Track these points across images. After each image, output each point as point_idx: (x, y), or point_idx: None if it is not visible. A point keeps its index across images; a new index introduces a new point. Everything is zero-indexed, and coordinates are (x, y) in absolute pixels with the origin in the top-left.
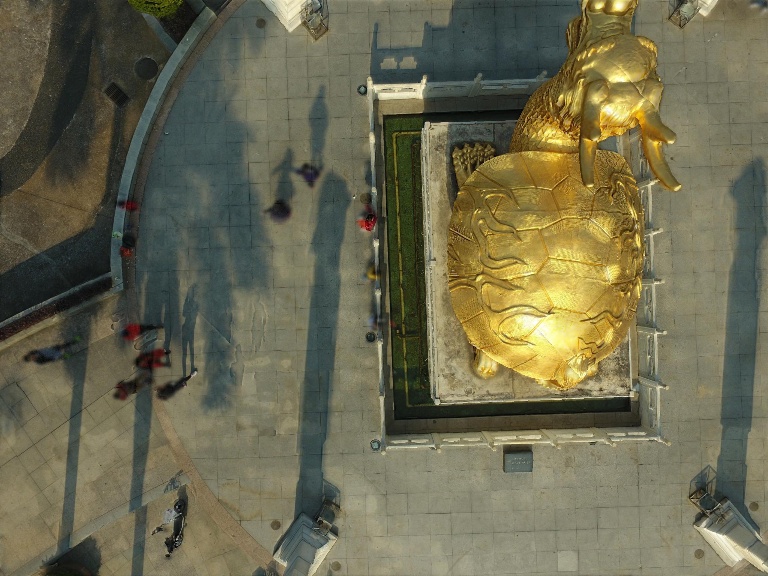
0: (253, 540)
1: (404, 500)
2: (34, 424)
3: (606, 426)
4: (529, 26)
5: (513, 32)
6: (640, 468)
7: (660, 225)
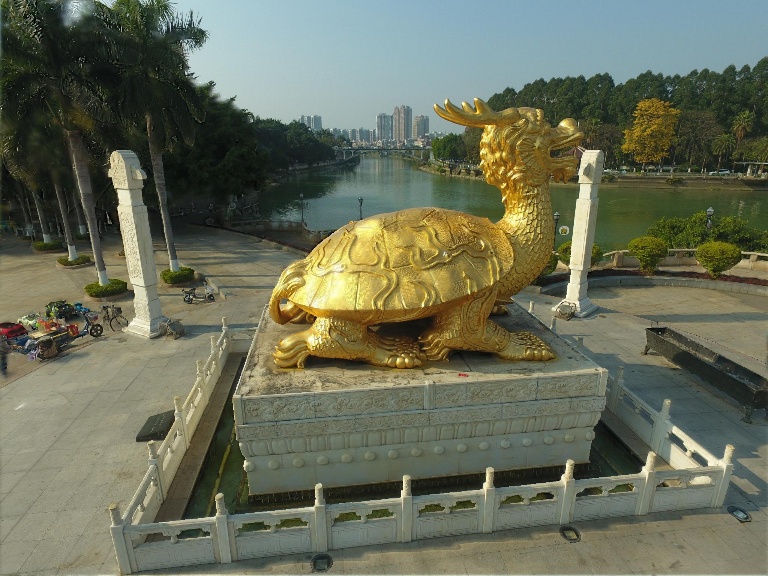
0: (172, 314)
1: (160, 365)
2: (281, 269)
3: (160, 514)
4: (689, 408)
5: (669, 398)
6: (51, 571)
7: (519, 566)
